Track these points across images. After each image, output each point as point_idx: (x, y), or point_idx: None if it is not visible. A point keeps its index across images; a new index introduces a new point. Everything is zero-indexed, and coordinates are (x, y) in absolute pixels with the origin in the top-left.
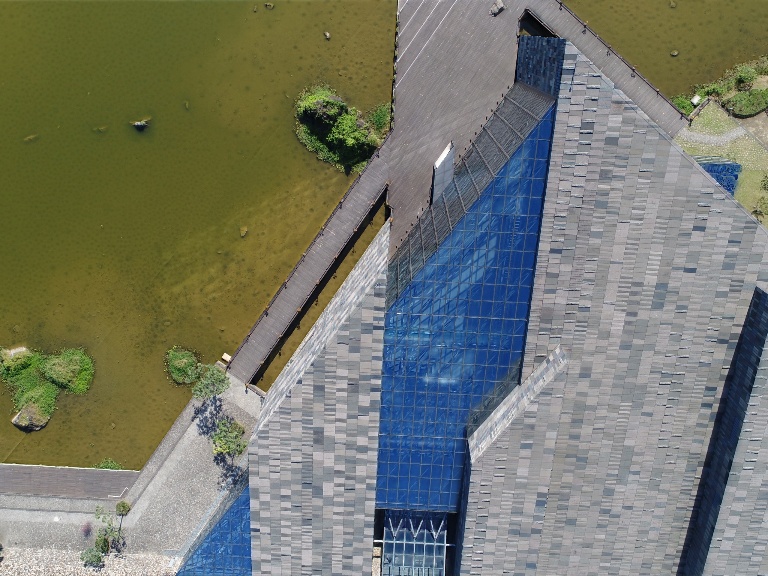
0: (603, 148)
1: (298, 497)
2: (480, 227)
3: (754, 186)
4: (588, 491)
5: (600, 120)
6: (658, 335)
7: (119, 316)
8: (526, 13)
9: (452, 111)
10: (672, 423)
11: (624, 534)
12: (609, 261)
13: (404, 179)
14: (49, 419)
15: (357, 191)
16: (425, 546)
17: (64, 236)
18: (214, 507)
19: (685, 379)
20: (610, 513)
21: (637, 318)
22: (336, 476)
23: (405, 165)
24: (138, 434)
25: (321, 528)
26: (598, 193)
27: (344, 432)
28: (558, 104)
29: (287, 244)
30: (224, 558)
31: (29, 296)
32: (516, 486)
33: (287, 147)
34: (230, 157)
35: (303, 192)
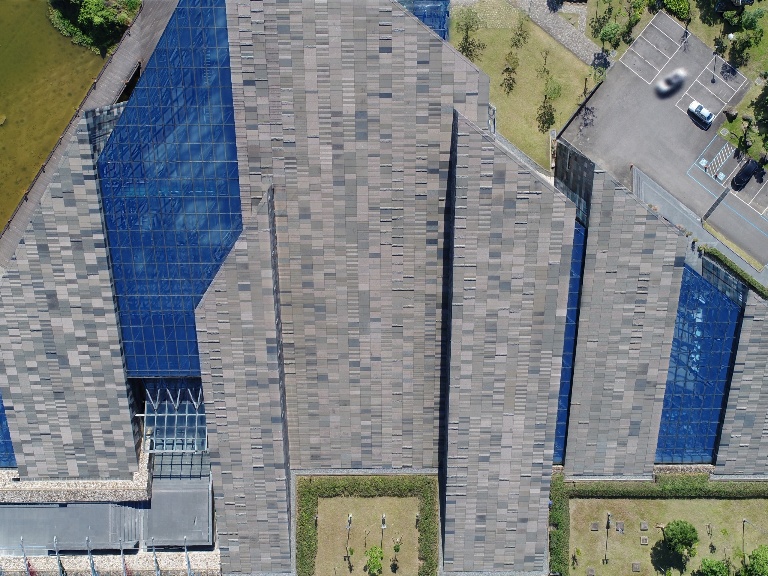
0: None
1: (45, 369)
2: (172, 63)
3: (505, 44)
4: (333, 343)
5: None
6: (368, 168)
7: None
8: None
9: None
10: (401, 263)
11: (378, 388)
12: (304, 91)
13: None
14: None
15: (110, 71)
16: (187, 417)
17: None
18: None
19: (405, 214)
20: (360, 366)
21: (344, 151)
22: (79, 343)
23: None
24: None
25: (75, 402)
26: (278, 18)
27: (77, 294)
28: None
29: (47, 130)
30: None
31: None
32: (243, 332)
33: (42, 33)
34: None
35: (60, 77)
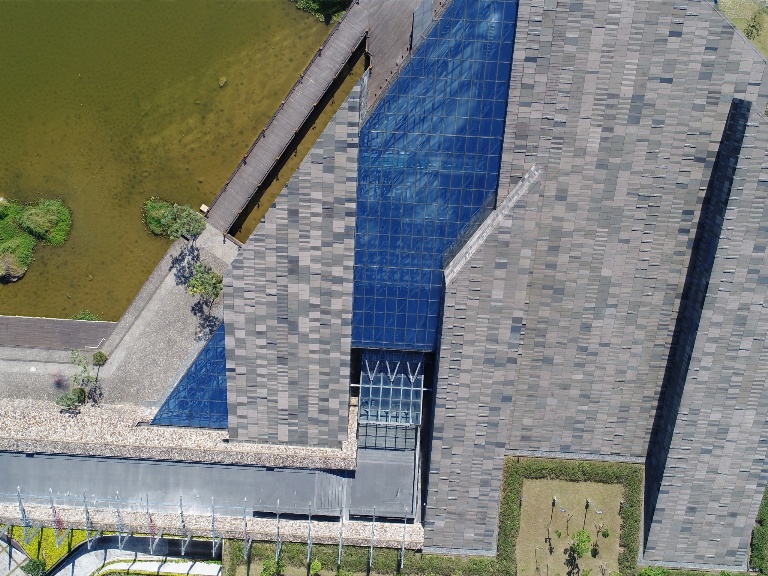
0: None
1: (273, 333)
2: (454, 35)
3: None
4: (565, 326)
5: None
6: (634, 153)
7: (97, 167)
8: None
9: None
10: (649, 251)
11: (602, 374)
12: (584, 71)
13: (384, 26)
14: (26, 270)
15: (336, 38)
16: (402, 390)
17: (42, 86)
18: (191, 358)
19: (662, 202)
20: (587, 351)
21: (613, 134)
22: (311, 310)
23: (385, 12)
24: (115, 286)
25: (297, 368)
26: None
27: (319, 261)
28: None
29: (266, 94)
30: (201, 409)
31: (6, 146)
32: (491, 310)
33: None
34: (209, 6)
35: (282, 42)
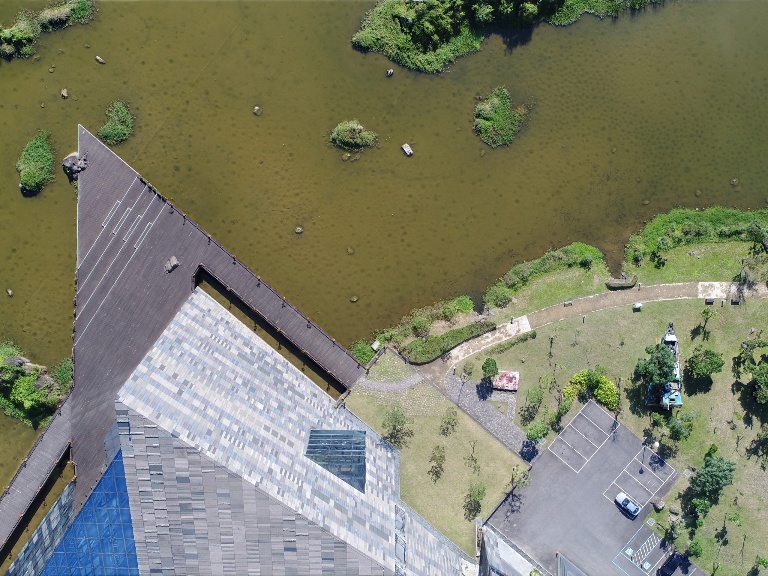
0: (177, 486)
1: None
2: (80, 549)
3: (433, 432)
4: None
5: (167, 463)
6: None
7: None
8: (200, 268)
9: (131, 367)
10: None
11: None
12: None
13: (87, 436)
14: None
15: (41, 449)
16: None
17: None
18: None
19: None
20: None
21: None
22: None
23: (87, 422)
24: None
25: None
26: (183, 522)
27: None
28: (122, 451)
29: None
30: None
31: None
32: None
33: None
34: None
35: None
